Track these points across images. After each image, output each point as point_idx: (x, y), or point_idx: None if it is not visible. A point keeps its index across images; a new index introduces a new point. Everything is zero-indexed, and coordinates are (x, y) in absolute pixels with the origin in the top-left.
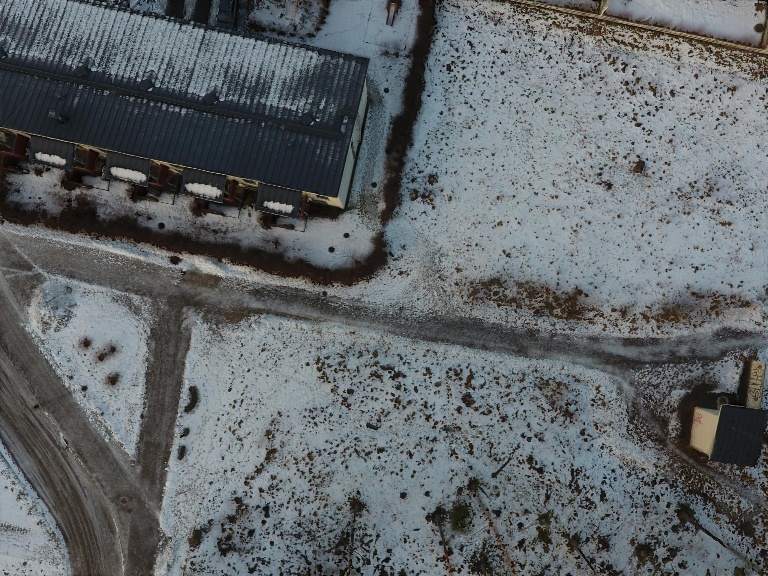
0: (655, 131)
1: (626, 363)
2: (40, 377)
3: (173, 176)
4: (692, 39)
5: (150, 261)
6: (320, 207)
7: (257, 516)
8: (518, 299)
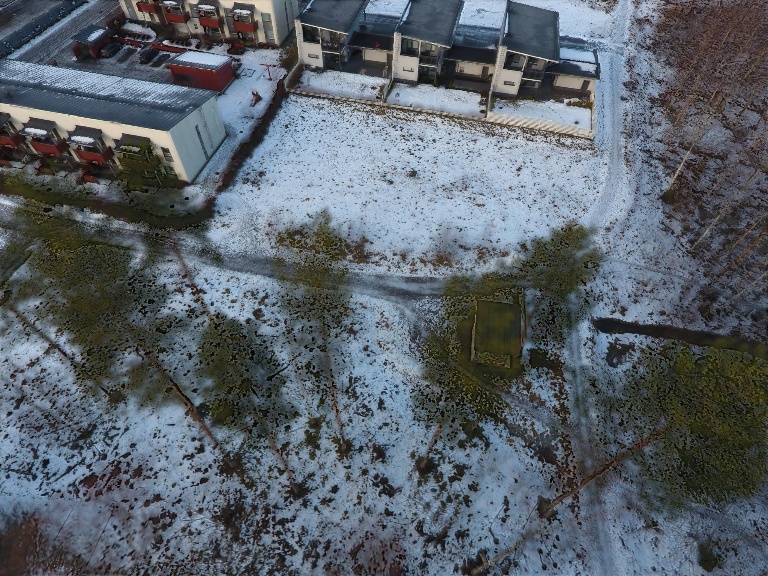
0: (424, 158)
1: (408, 295)
2: None
3: (74, 163)
4: (441, 115)
5: (27, 209)
6: (172, 181)
7: (6, 408)
8: (317, 247)
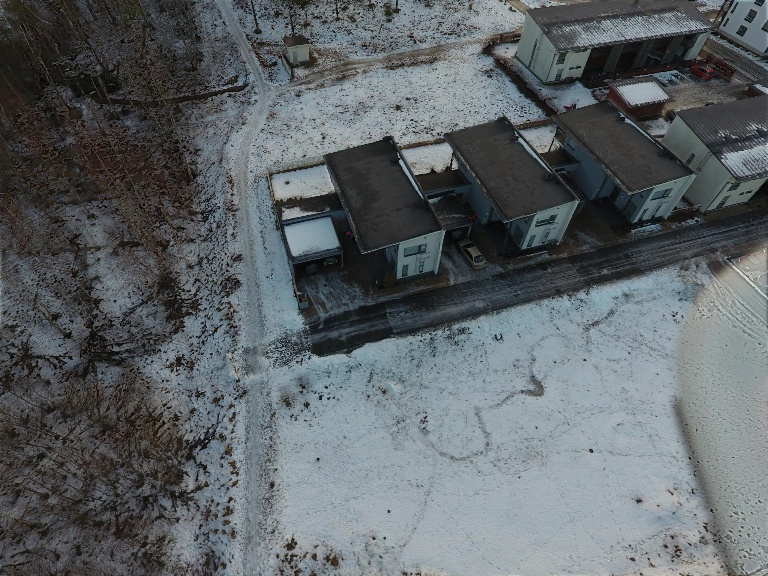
0: (401, 121)
1: None
2: (567, 1)
3: None
4: None
5: None
6: None
7: None
8: None
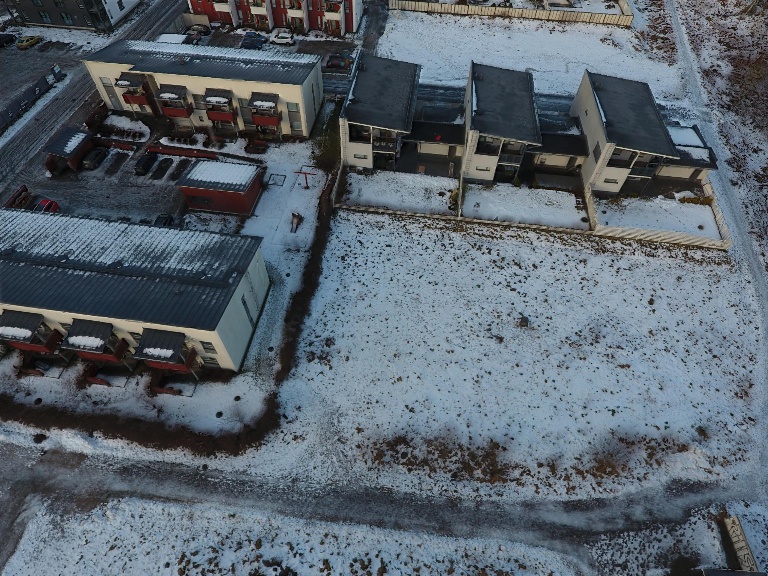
0: (530, 294)
1: (576, 535)
2: None
3: (69, 352)
4: (536, 229)
5: (10, 441)
6: (213, 371)
7: None
8: (430, 460)
